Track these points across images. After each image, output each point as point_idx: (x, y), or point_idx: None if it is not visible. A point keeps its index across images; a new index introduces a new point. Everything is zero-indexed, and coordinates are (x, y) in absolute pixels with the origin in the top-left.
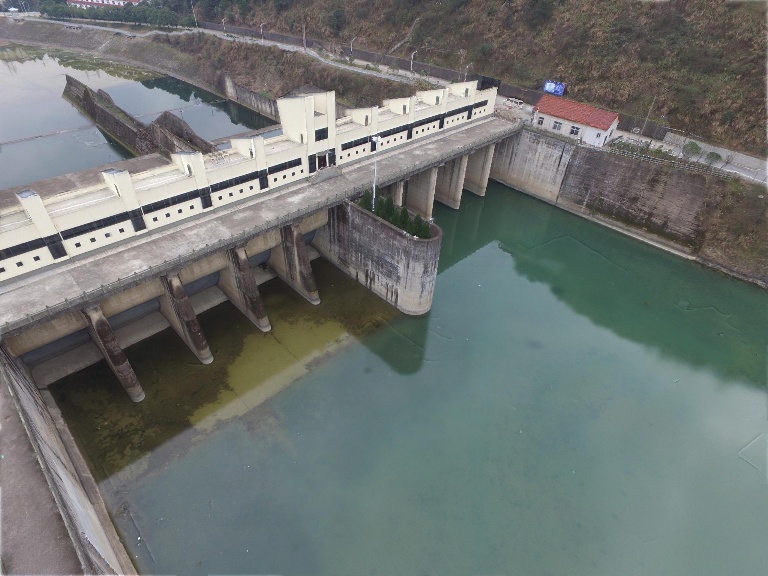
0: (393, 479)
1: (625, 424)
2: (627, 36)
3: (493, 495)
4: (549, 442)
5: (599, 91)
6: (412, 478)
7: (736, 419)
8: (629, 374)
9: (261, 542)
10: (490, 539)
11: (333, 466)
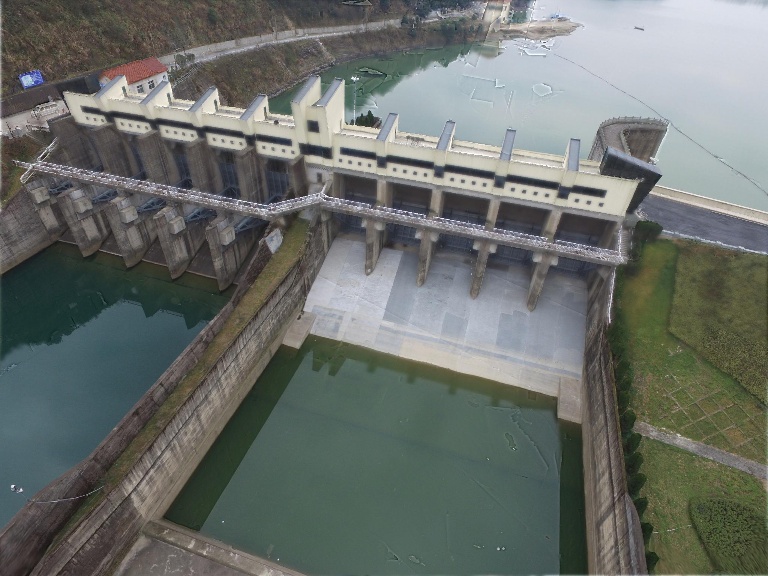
0: None
1: None
2: (7, 5)
3: None
4: None
5: (65, 61)
6: None
7: None
8: None
9: None
10: None
11: None
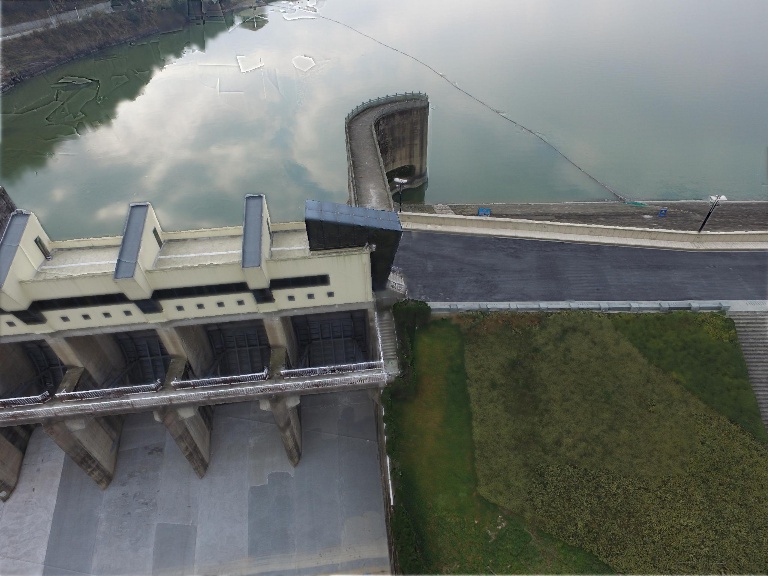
0: (215, 205)
1: (93, 176)
2: None
3: (187, 185)
4: (133, 187)
5: None
6: (207, 202)
7: (53, 159)
8: (41, 188)
9: (292, 207)
10: (210, 176)
11: (232, 221)
